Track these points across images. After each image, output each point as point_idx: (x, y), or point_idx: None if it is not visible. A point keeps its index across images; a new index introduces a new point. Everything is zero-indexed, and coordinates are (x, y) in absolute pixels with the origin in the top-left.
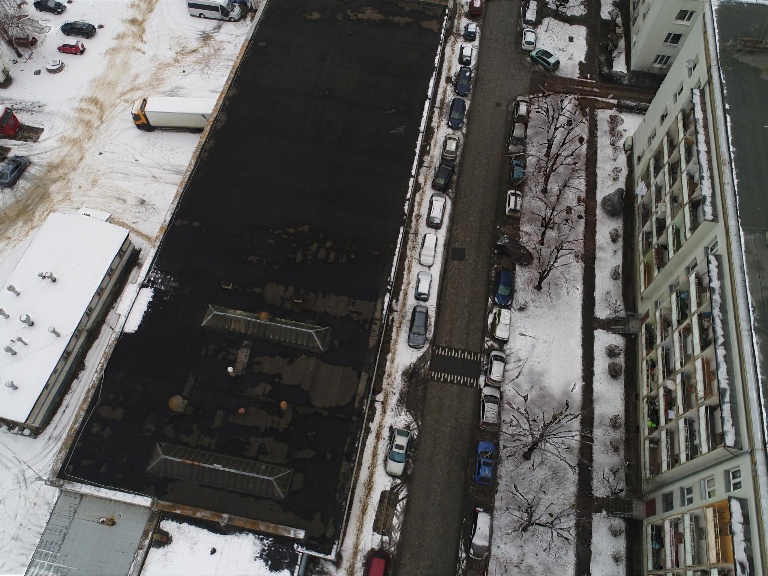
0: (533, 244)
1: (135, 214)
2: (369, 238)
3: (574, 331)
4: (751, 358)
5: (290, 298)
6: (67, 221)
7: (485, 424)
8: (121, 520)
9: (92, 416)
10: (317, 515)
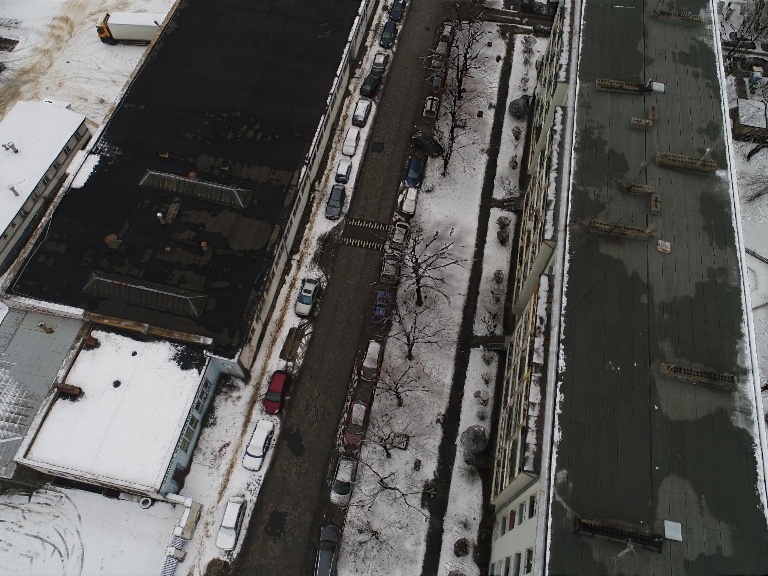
0: (445, 140)
1: (94, 110)
2: (293, 123)
3: (473, 209)
4: (568, 169)
5: (219, 167)
6: (31, 107)
7: (384, 276)
8: (58, 329)
9: (39, 249)
10: (225, 330)
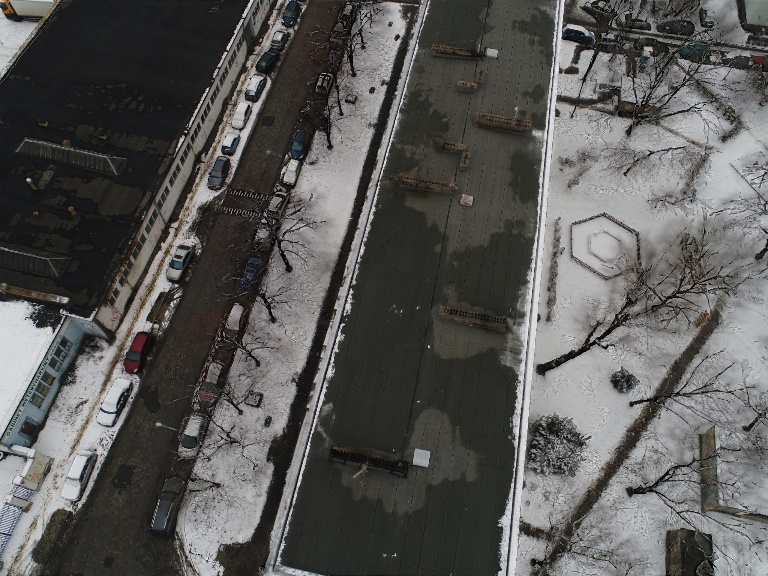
0: (334, 115)
1: None
2: (177, 95)
3: (353, 180)
4: (391, 129)
5: (97, 136)
6: None
7: (256, 243)
8: None
9: None
10: (84, 290)
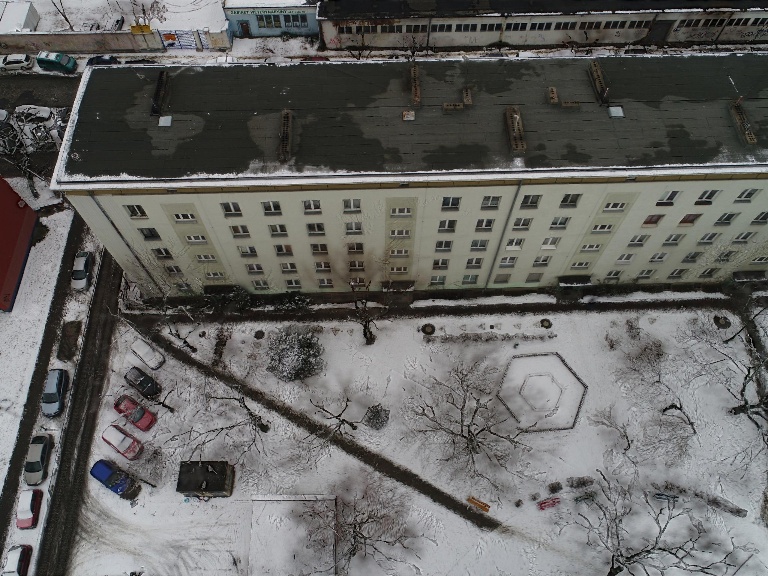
0: None
1: None
2: None
3: None
4: None
5: None
6: None
7: None
8: None
9: None
10: (339, 7)
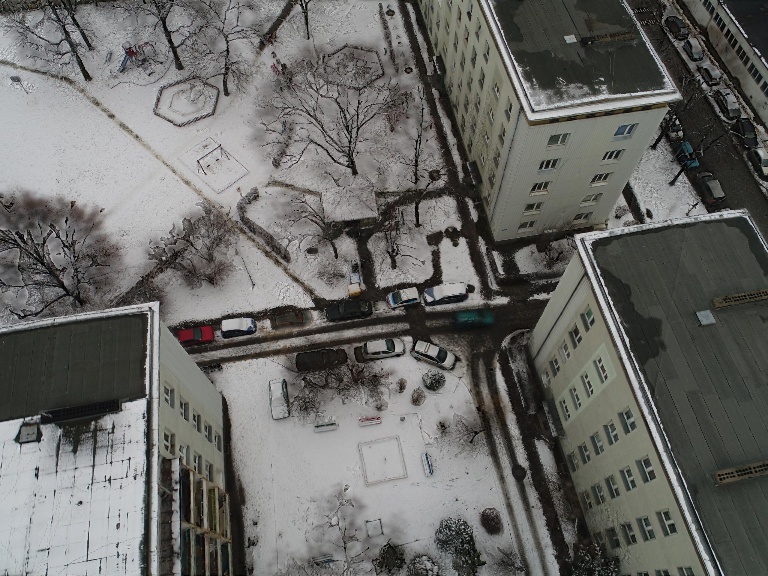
0: None
1: None
2: (763, 23)
3: None
4: None
5: None
6: None
7: None
8: None
9: None
10: None
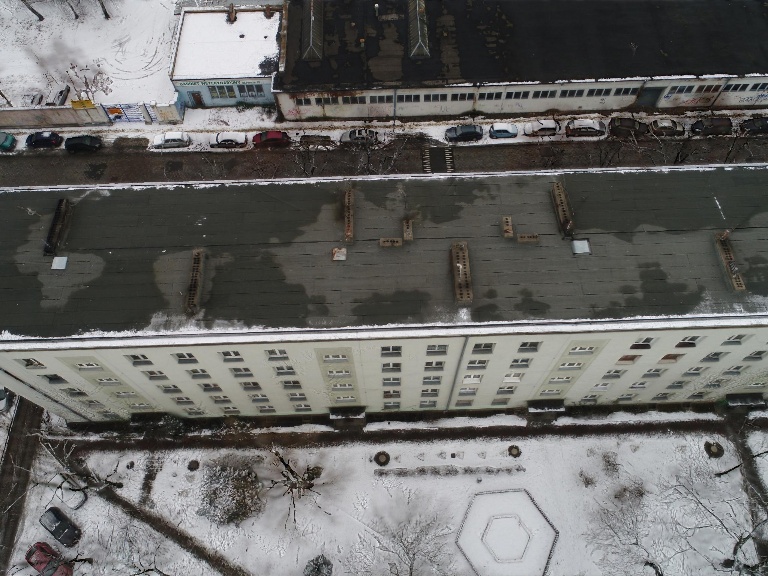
0: None
1: None
2: (519, 64)
3: None
4: None
5: None
6: None
7: None
8: None
9: None
10: (296, 78)
